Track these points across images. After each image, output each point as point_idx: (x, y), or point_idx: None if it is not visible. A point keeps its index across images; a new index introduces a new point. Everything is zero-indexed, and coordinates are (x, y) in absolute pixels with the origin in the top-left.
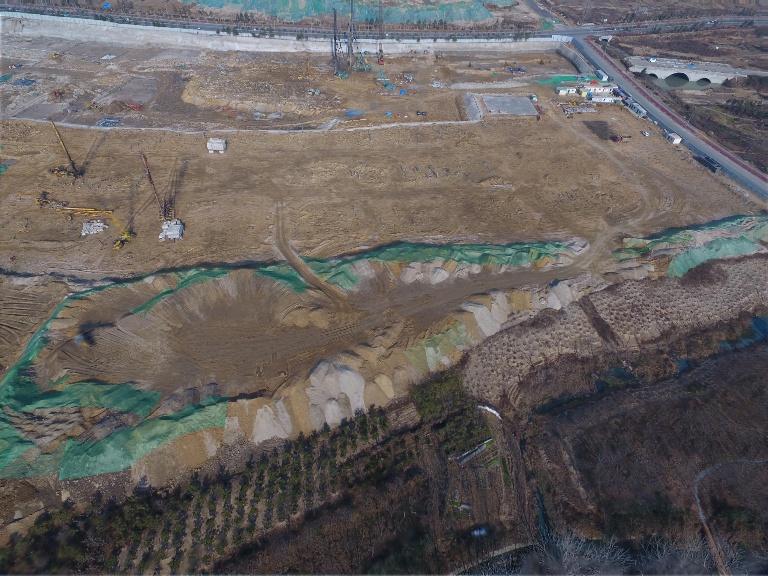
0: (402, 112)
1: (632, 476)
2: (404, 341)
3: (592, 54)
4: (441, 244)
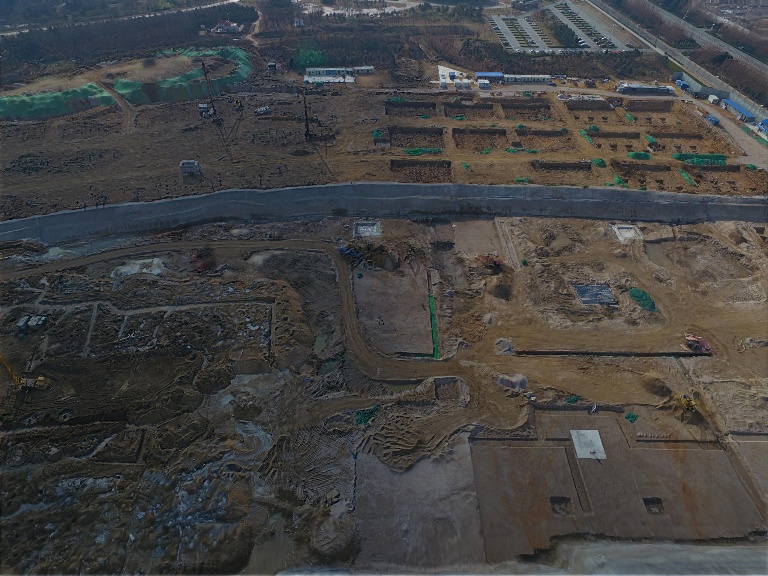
0: None
1: (1, 66)
2: None
3: None
4: (7, 120)
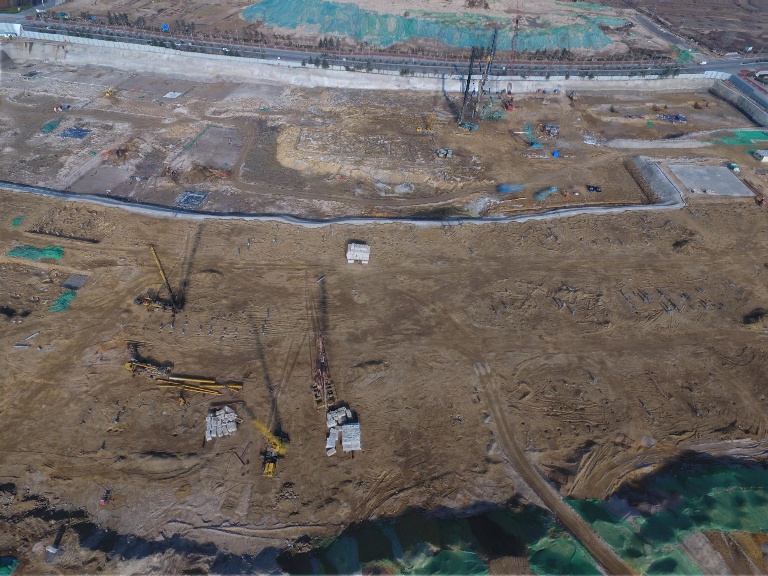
0: (567, 186)
1: None
2: None
3: (763, 98)
4: (760, 460)
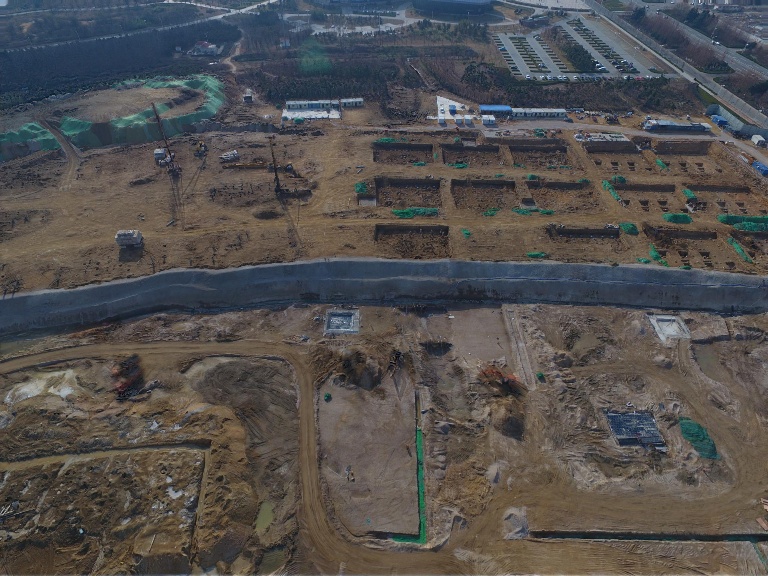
0: None
1: None
2: (12, 109)
3: None
4: None
